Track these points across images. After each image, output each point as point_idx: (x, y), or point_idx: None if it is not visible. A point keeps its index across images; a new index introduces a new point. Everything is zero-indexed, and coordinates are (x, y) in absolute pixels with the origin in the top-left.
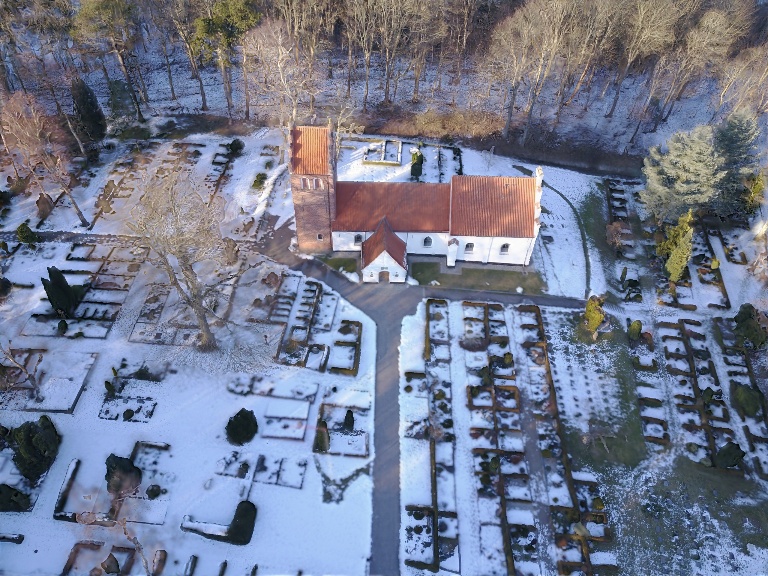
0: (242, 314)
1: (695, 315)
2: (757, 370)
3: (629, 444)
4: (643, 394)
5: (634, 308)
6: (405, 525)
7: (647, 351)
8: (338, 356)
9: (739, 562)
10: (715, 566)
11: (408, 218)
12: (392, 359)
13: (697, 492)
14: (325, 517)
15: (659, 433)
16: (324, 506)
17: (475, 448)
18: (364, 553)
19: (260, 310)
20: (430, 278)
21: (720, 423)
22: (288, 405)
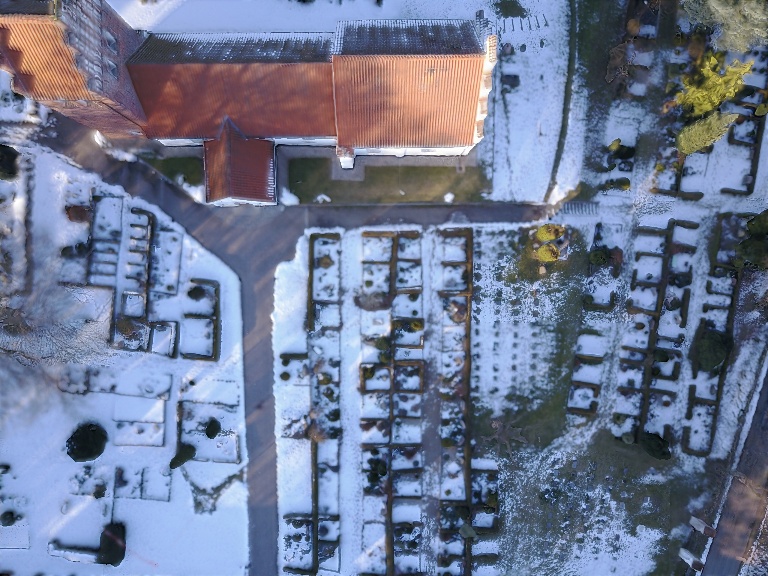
0: (51, 272)
1: (696, 209)
2: (743, 300)
3: (546, 422)
4: (584, 346)
5: (613, 202)
6: (283, 534)
7: (609, 278)
8: (192, 334)
9: (622, 544)
10: (596, 549)
11: (267, 119)
12: (263, 333)
13: (606, 472)
14: (199, 528)
15: (587, 401)
16: (196, 518)
17: (364, 443)
18: (242, 563)
19: (74, 265)
20: (316, 191)
21: (665, 382)
22: (138, 405)
